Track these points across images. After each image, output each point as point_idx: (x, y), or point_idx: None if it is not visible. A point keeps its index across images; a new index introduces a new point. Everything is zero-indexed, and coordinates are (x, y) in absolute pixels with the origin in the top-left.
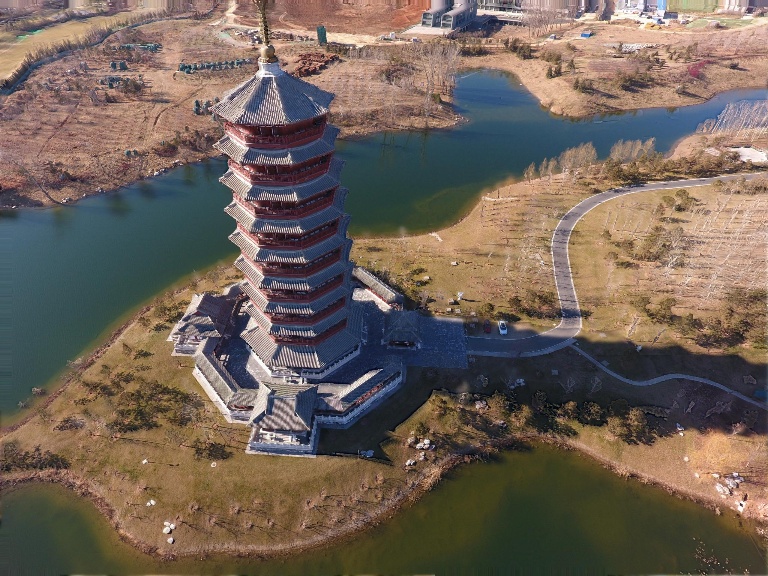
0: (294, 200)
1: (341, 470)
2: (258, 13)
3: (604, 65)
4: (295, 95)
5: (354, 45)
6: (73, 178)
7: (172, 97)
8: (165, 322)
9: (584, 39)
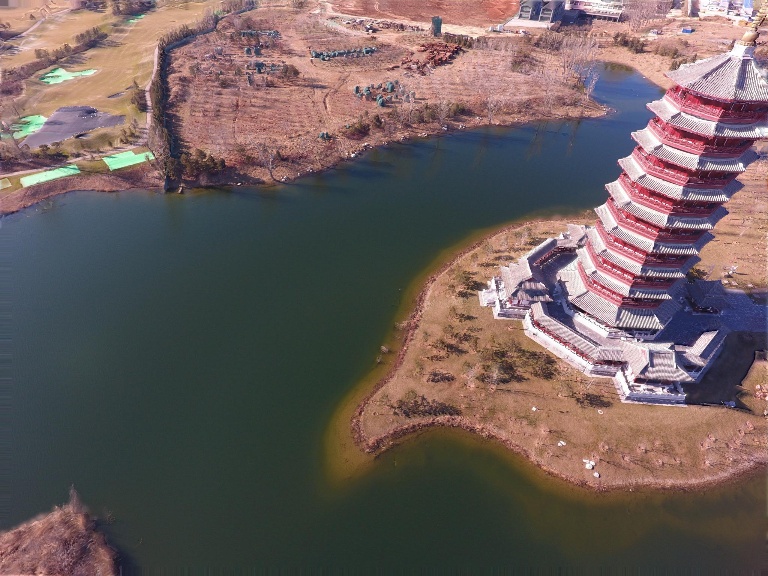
0: (742, 170)
1: (716, 417)
2: (766, 2)
3: None
4: (765, 76)
5: (468, 36)
6: (282, 158)
7: (326, 83)
8: (467, 290)
9: (688, 35)
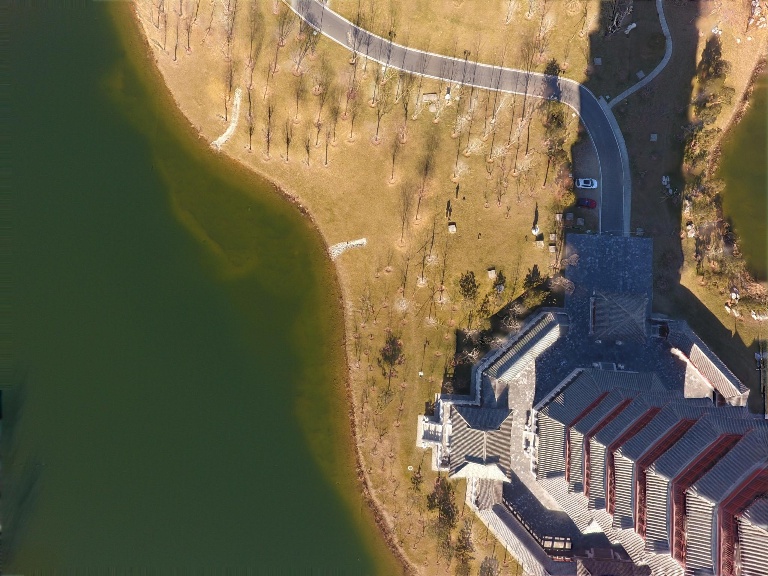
0: None
1: None
2: None
3: None
4: None
5: None
6: None
7: None
8: None
9: None
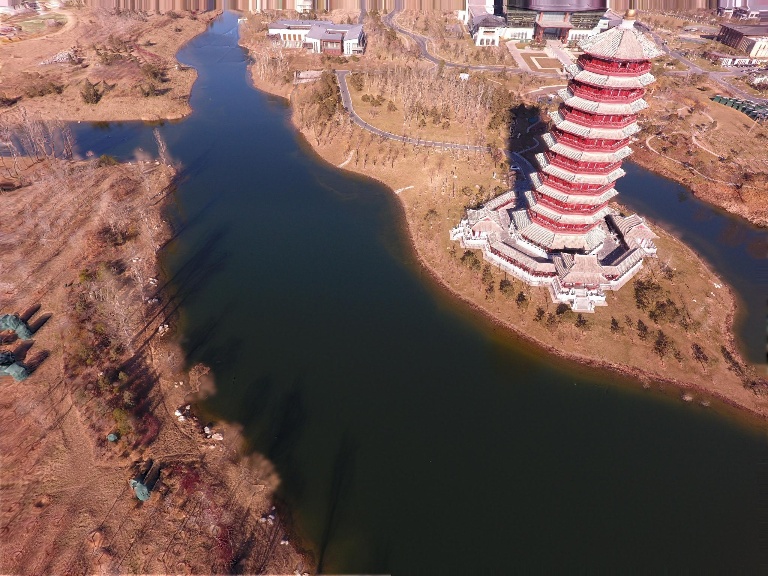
0: None
1: None
2: None
3: (106, 73)
4: None
5: None
6: None
7: None
8: None
9: (3, 67)
